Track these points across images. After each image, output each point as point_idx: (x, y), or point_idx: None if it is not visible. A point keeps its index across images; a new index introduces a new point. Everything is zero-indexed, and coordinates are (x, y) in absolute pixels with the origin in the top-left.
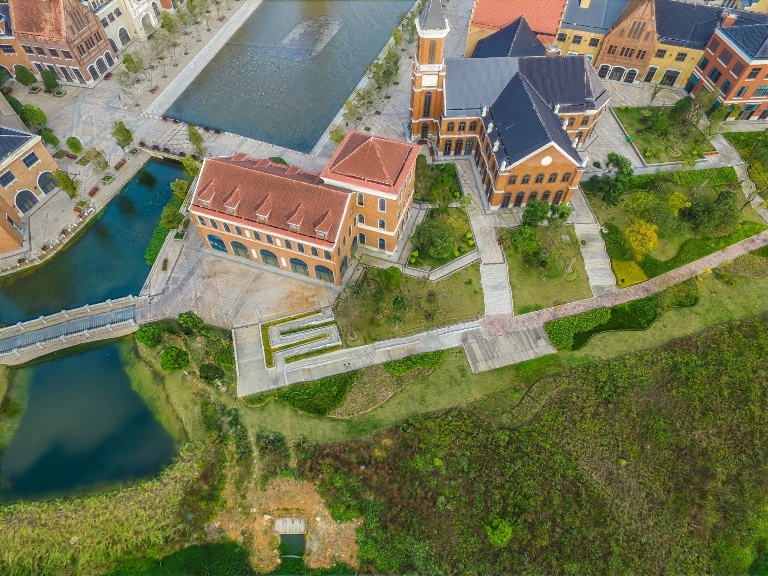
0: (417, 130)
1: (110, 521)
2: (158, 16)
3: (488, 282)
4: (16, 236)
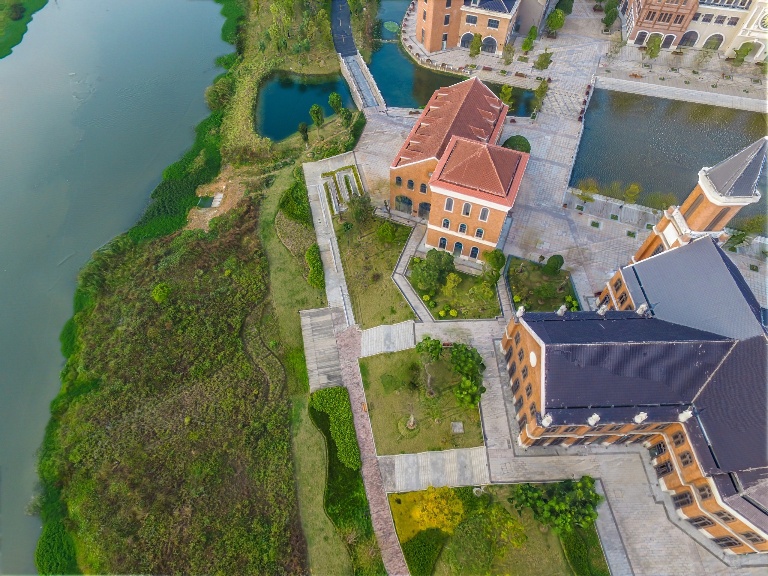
0: None
1: None
2: None
3: (395, 331)
4: (435, 46)
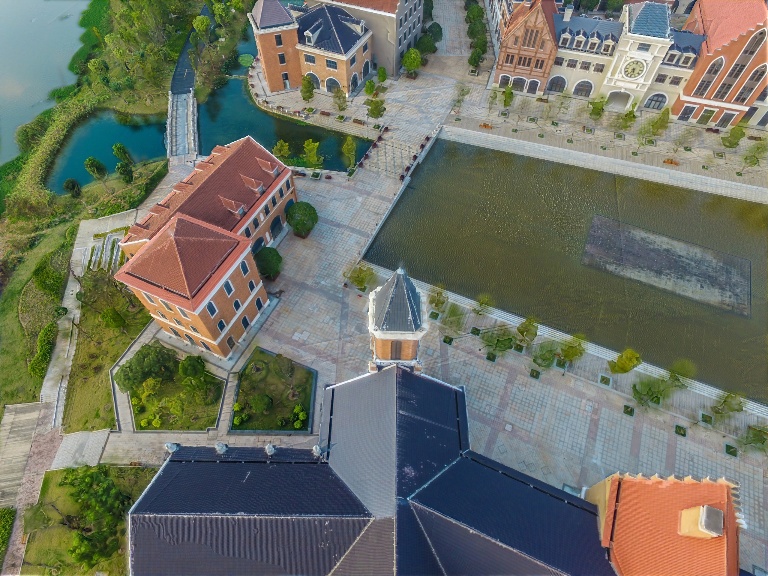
0: None
1: None
2: (654, 109)
3: (91, 440)
4: (276, 85)
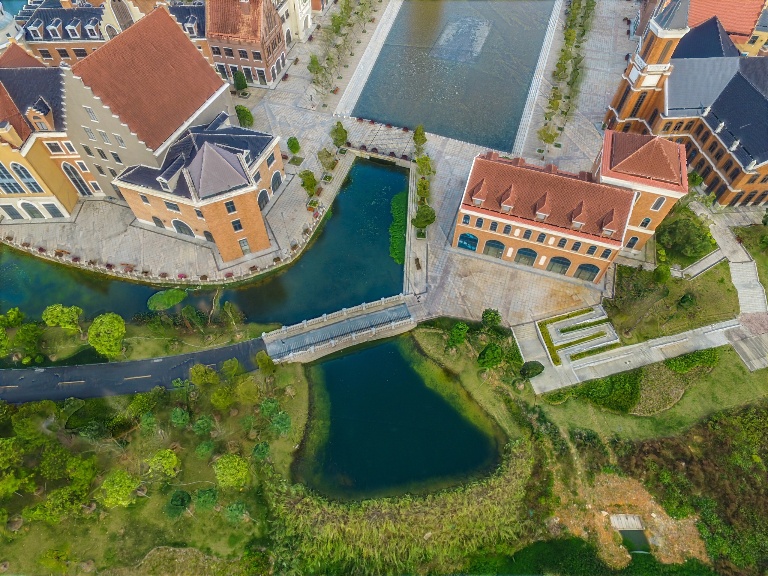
0: (618, 130)
1: (465, 517)
2: None
3: (738, 280)
4: None
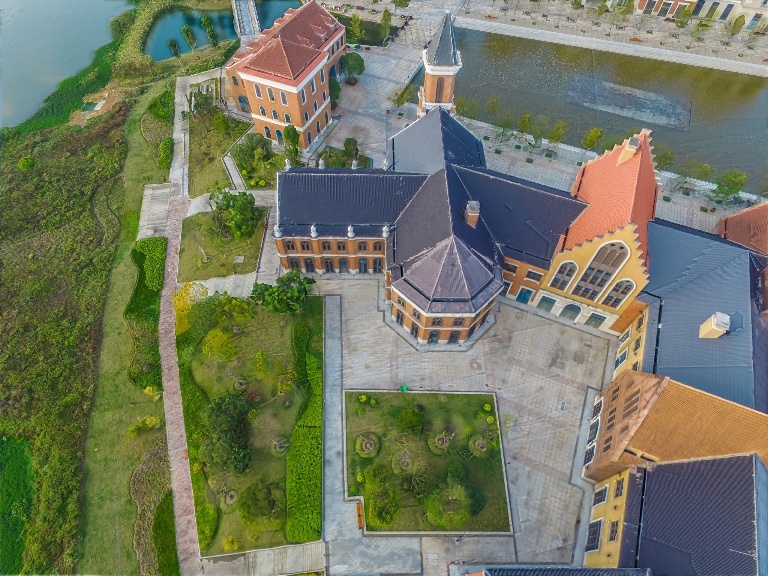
0: None
1: None
2: (625, 7)
3: None
4: None
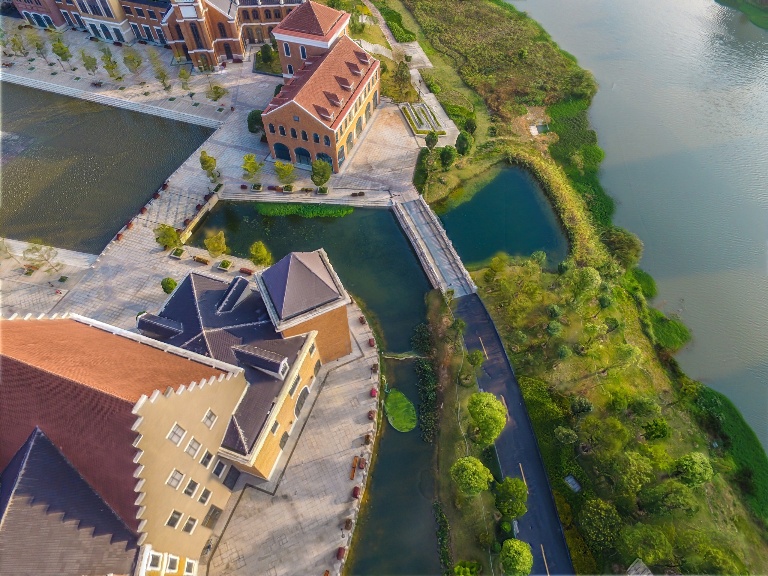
0: None
1: None
2: None
3: (372, 51)
4: None
